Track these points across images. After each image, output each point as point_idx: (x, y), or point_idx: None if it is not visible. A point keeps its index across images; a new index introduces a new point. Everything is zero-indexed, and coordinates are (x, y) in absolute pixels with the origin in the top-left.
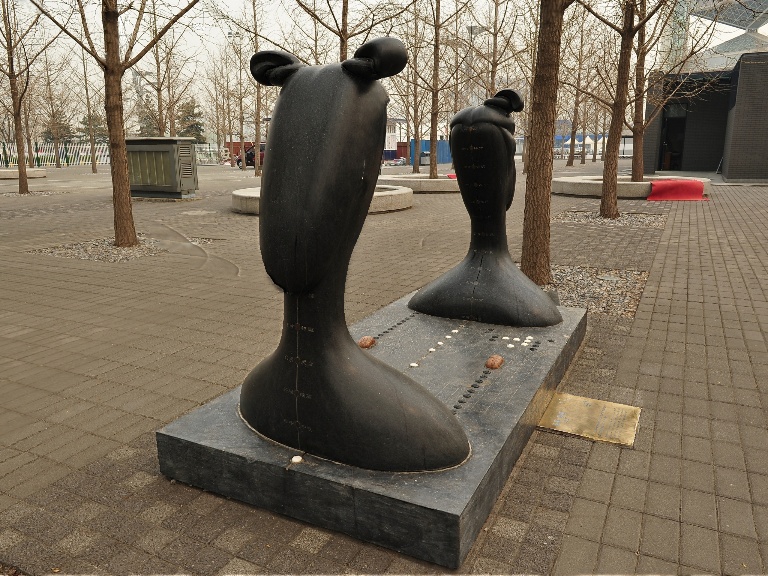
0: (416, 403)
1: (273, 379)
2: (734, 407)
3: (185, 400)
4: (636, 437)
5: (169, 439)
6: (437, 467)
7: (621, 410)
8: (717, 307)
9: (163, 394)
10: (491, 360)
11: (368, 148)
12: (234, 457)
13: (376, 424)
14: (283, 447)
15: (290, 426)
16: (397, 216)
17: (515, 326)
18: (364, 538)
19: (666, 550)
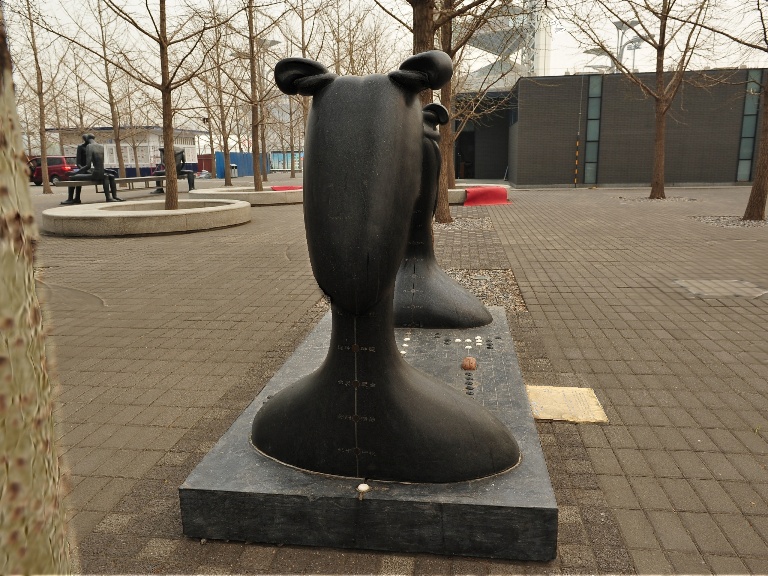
0: (475, 410)
1: (321, 407)
2: (656, 377)
3: (147, 450)
4: (605, 414)
5: (199, 494)
6: (503, 468)
7: (578, 393)
8: (585, 295)
9: (114, 448)
10: (468, 362)
11: (421, 161)
12: (291, 498)
13: (446, 436)
14: (338, 478)
15: (347, 454)
16: (241, 231)
17: (457, 328)
18: (452, 552)
19: (693, 504)
